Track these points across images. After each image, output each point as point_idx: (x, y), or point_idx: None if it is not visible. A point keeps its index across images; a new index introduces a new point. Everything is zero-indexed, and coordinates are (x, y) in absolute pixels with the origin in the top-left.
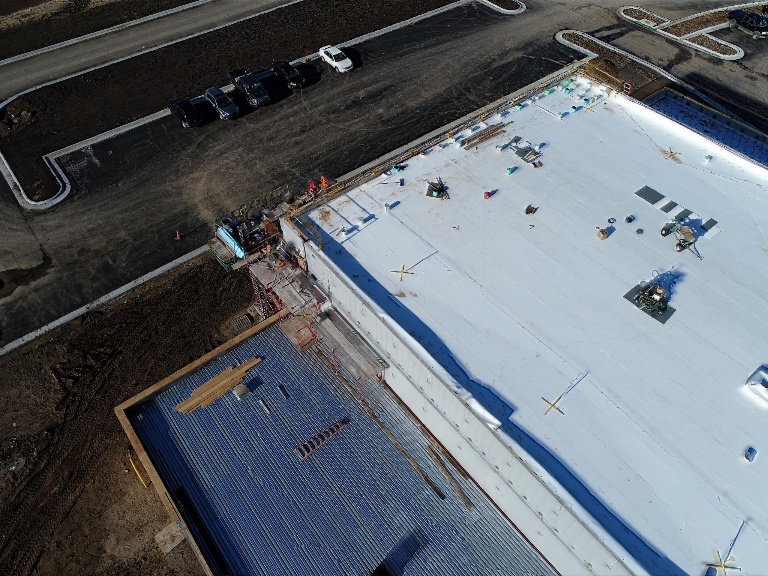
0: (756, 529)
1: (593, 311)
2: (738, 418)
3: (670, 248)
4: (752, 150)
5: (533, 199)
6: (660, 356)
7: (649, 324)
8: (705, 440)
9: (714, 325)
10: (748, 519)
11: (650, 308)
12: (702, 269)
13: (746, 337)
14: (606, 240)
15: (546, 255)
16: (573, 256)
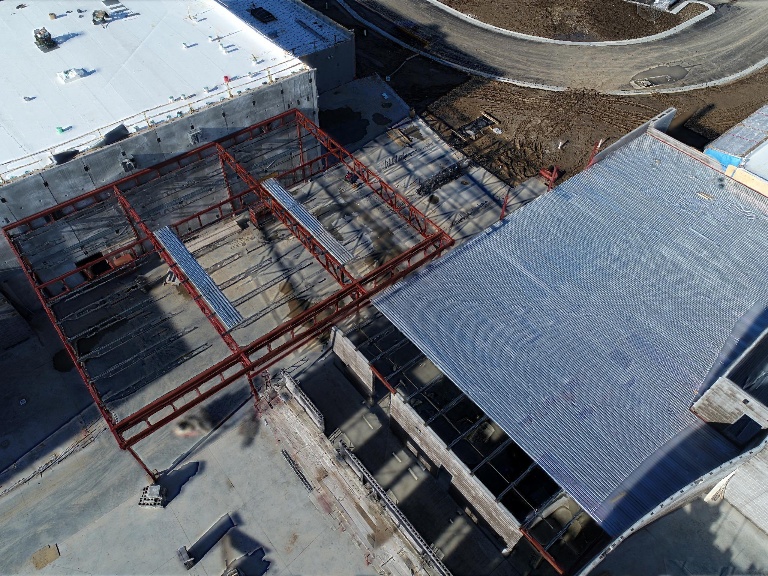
0: (1, 123)
1: (8, 48)
2: (42, 87)
3: (91, 24)
4: (284, 8)
5: (29, 2)
6: (27, 65)
7: (36, 53)
8: (12, 94)
9: (75, 53)
10: (0, 120)
11: (39, 44)
12: (100, 32)
13: (88, 58)
14: (54, 20)
15: (8, 26)
16: (24, 26)
